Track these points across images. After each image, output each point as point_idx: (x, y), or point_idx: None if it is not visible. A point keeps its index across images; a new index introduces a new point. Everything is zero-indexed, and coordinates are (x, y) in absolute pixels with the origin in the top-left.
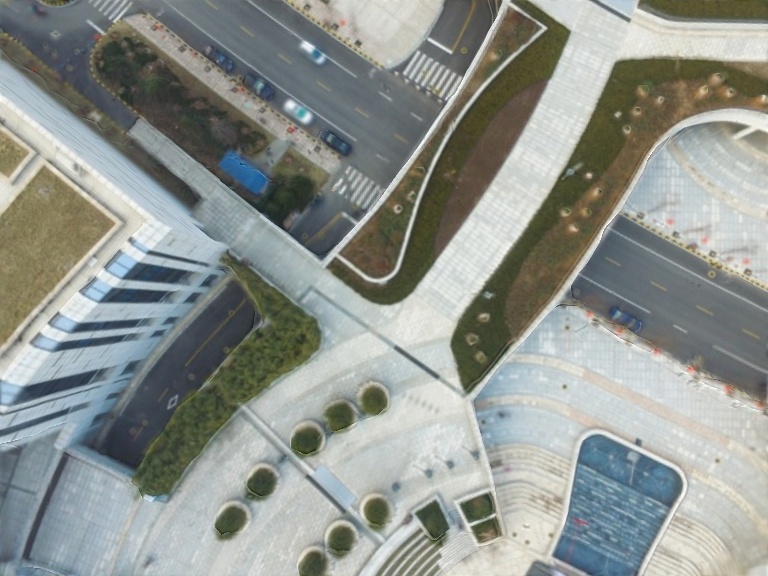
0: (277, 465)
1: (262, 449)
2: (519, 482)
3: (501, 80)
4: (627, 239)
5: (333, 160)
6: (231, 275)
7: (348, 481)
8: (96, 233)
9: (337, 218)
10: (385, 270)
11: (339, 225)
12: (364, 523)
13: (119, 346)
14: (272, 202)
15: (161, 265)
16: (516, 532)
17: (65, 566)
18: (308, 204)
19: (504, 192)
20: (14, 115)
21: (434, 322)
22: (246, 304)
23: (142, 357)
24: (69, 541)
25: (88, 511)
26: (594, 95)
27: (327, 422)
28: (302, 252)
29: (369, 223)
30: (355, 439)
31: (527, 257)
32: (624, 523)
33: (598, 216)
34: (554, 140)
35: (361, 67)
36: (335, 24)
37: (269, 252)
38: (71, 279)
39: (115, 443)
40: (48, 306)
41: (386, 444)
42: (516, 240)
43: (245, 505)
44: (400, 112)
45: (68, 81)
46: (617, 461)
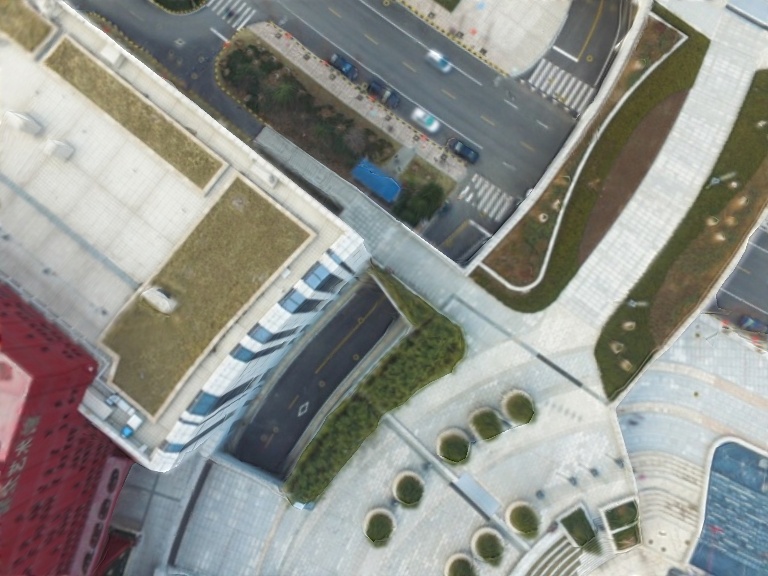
0: (422, 473)
1: (405, 457)
2: (653, 489)
3: (644, 89)
4: (756, 247)
5: (460, 168)
6: (363, 283)
7: (492, 489)
8: (290, 245)
9: (464, 226)
10: (529, 278)
11: (467, 233)
12: (509, 530)
13: (272, 354)
14: (407, 210)
15: (337, 275)
16: (652, 539)
17: (210, 573)
18: (436, 212)
19: (648, 201)
20: (209, 127)
21: (577, 330)
22: (377, 311)
23: (275, 364)
24: (214, 548)
25: (232, 518)
26: (735, 104)
27: (475, 430)
28: (446, 260)
29: (513, 232)
30: (498, 447)
31: (672, 266)
32: (759, 530)
33: (743, 225)
34: (697, 149)
35: (486, 75)
36: (460, 32)
37: (411, 260)
38: (265, 290)
39: (247, 450)
40: (242, 317)
41: (529, 452)
42: (660, 249)
43: (391, 512)
44: (526, 120)
45: (193, 89)
46: (749, 468)
